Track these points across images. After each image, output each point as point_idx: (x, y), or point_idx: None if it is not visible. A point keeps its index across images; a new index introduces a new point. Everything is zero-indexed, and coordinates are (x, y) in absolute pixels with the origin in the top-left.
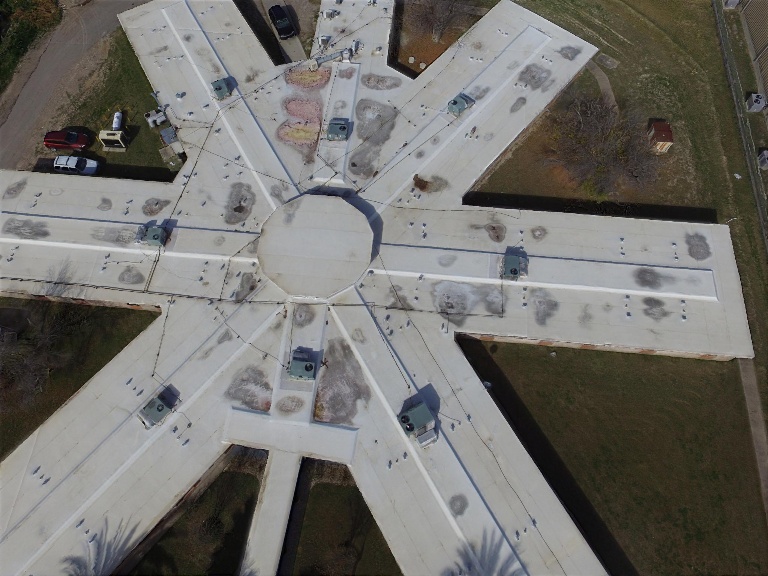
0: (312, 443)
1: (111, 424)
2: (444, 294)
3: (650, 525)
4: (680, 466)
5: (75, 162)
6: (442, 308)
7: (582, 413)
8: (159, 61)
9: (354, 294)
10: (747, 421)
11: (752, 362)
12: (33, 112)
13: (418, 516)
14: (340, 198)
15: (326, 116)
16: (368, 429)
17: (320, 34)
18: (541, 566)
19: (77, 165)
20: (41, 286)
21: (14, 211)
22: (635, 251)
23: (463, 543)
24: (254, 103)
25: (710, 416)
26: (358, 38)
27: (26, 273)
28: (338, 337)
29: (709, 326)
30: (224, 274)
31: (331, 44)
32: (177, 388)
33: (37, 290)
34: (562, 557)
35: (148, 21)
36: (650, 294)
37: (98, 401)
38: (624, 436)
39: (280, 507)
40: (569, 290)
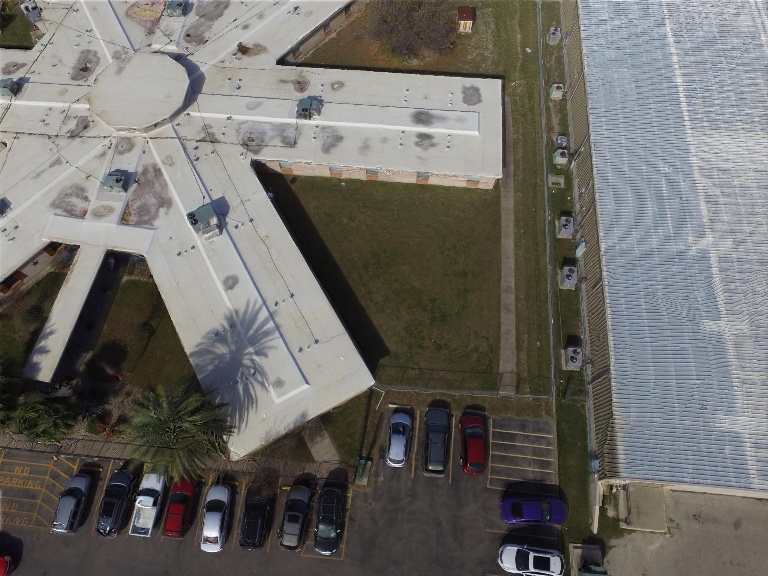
0: (116, 239)
1: None
2: (247, 131)
3: (403, 310)
4: (436, 266)
5: None
6: (244, 141)
7: (360, 228)
8: None
9: (170, 130)
10: (499, 233)
11: (512, 190)
12: None
13: (196, 291)
14: (166, 55)
15: None
16: (165, 229)
17: None
18: (292, 326)
19: None
20: None
21: None
22: (416, 99)
23: (229, 309)
24: None
25: (469, 230)
26: None
27: None
28: (152, 163)
29: (468, 154)
30: (63, 117)
31: None
32: (10, 200)
33: None
34: (311, 320)
35: None
36: (422, 130)
37: None
38: (393, 245)
39: (82, 284)
40: (354, 127)
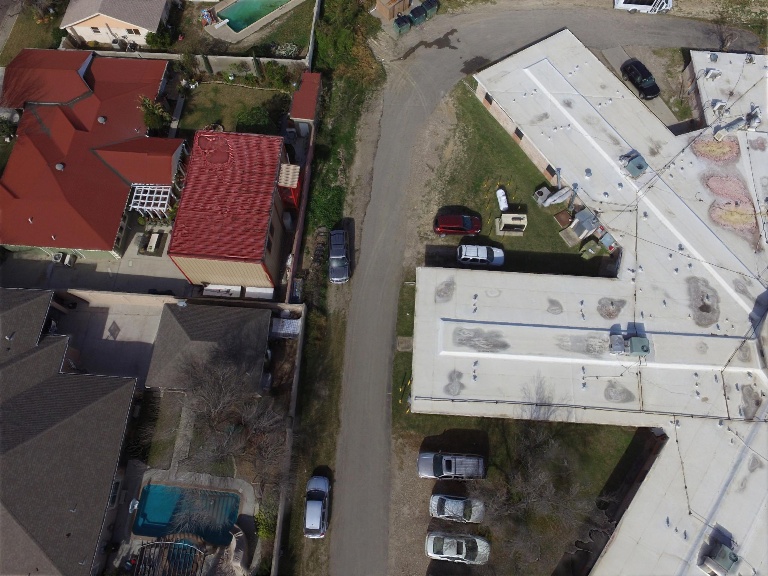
0: None
1: (666, 574)
2: None
3: None
4: None
5: (486, 253)
6: None
7: None
8: (546, 131)
9: None
10: None
11: None
12: (398, 189)
13: None
14: None
15: (758, 196)
16: None
17: (709, 97)
18: None
19: (487, 256)
20: (521, 409)
21: (455, 318)
22: None
23: None
24: (671, 181)
25: None
26: (751, 102)
27: (498, 393)
28: None
29: None
30: (721, 387)
31: (725, 109)
32: (726, 528)
33: (518, 414)
34: None
35: (514, 83)
36: None
37: (640, 546)
38: None
39: None
40: None
